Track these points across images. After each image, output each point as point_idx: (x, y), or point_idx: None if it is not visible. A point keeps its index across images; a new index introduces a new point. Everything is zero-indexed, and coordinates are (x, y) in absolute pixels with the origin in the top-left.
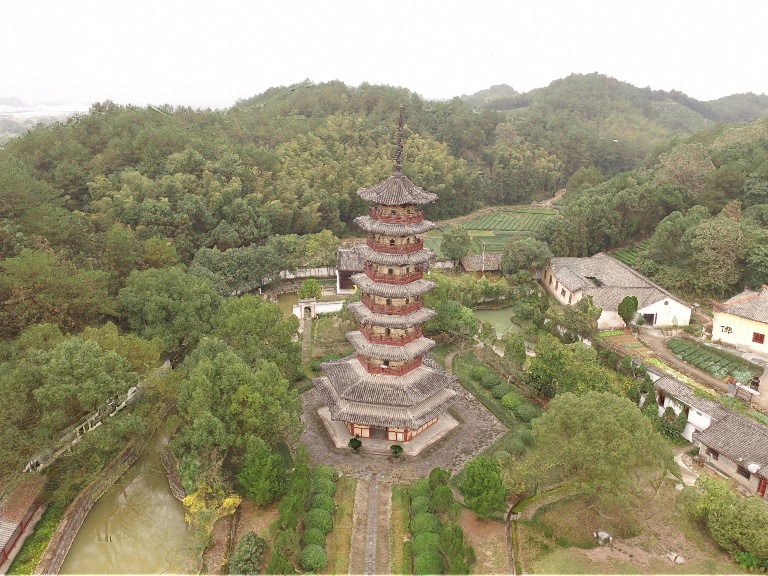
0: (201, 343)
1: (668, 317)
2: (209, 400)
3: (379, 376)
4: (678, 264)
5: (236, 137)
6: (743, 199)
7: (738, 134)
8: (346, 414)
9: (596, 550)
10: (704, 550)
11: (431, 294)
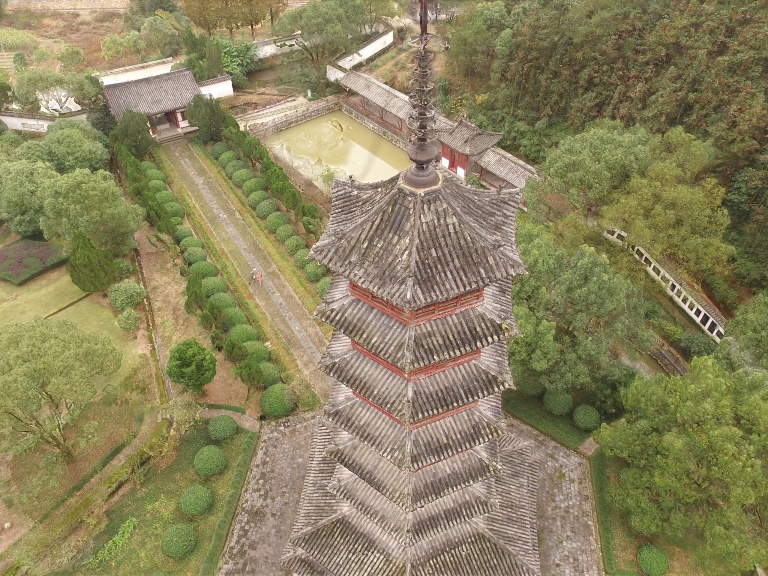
0: None
1: None
2: None
3: None
4: None
5: None
6: None
7: None
8: None
9: None
10: None
11: None
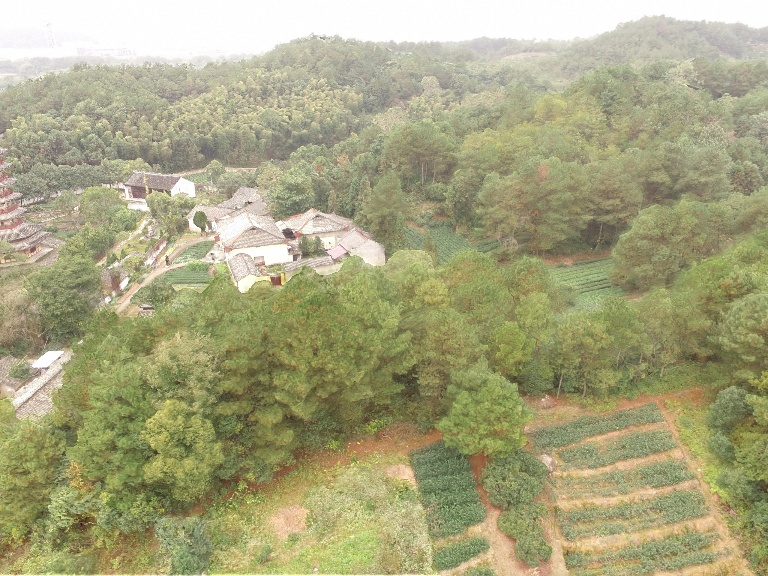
0: None
1: None
2: None
3: None
4: None
5: (187, 87)
6: None
7: (472, 99)
8: None
9: None
10: None
11: (94, 198)
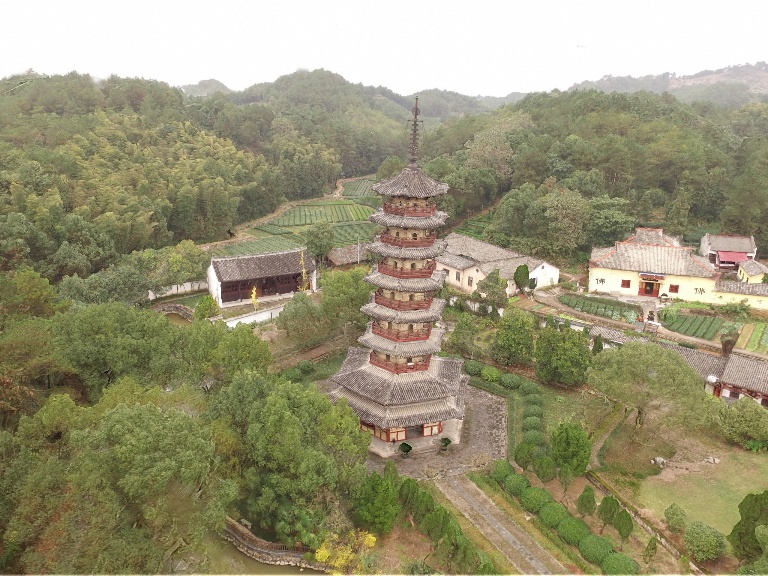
0: (237, 379)
1: (545, 279)
2: (299, 438)
3: (406, 375)
4: (527, 234)
5: None
6: (549, 176)
7: (512, 122)
8: (392, 420)
9: (663, 473)
10: (722, 448)
11: (370, 289)
